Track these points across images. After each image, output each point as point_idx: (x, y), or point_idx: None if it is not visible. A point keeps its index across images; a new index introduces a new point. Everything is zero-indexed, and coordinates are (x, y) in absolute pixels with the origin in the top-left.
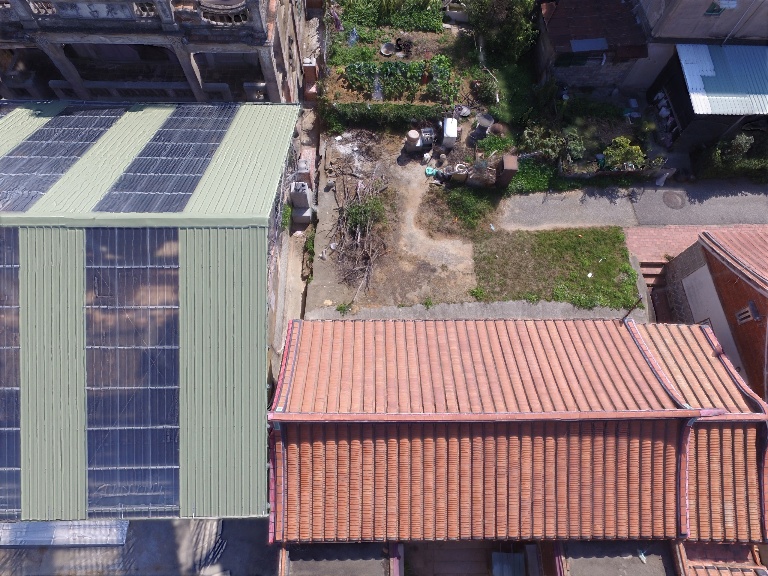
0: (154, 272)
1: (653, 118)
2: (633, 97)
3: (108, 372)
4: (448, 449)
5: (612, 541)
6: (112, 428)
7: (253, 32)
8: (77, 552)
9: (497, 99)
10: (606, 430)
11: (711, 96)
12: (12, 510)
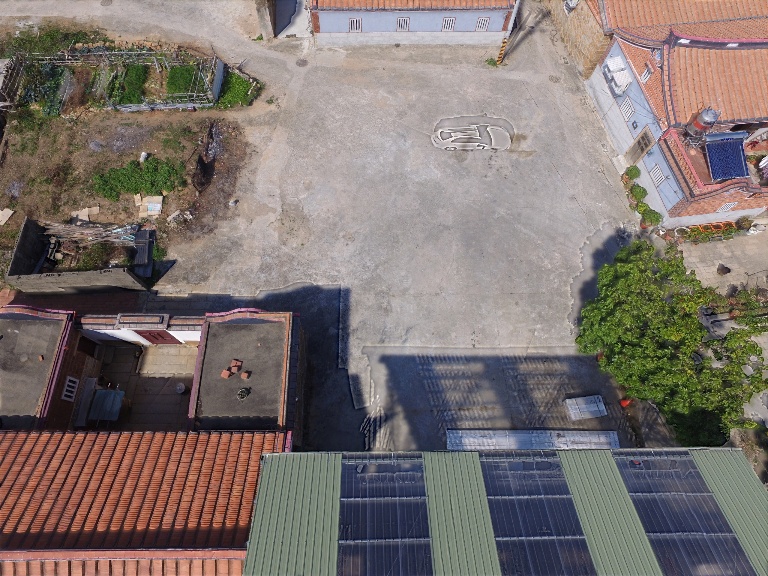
0: None
1: None
2: None
3: None
4: (98, 518)
5: None
6: (406, 540)
7: None
8: (485, 424)
9: None
10: None
11: None
12: (488, 460)
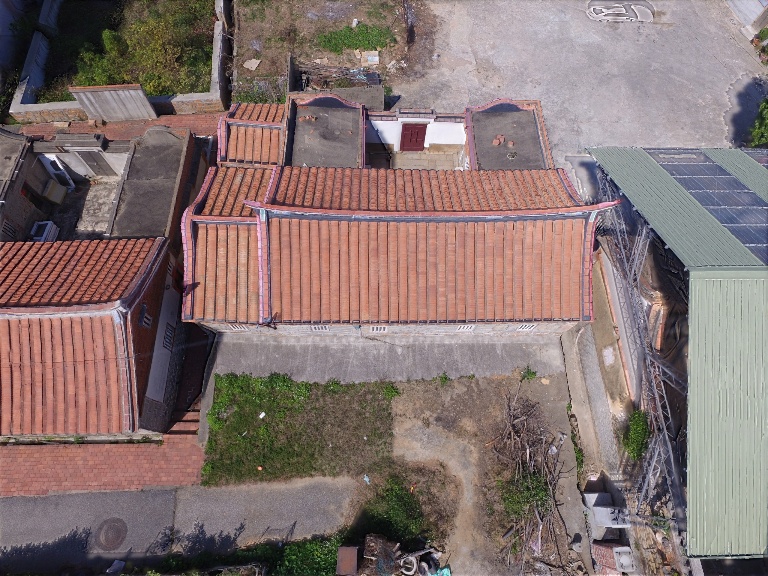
0: (760, 242)
1: None
2: None
3: None
4: (452, 206)
5: None
6: (717, 176)
7: None
8: None
9: None
10: None
11: None
12: (748, 152)
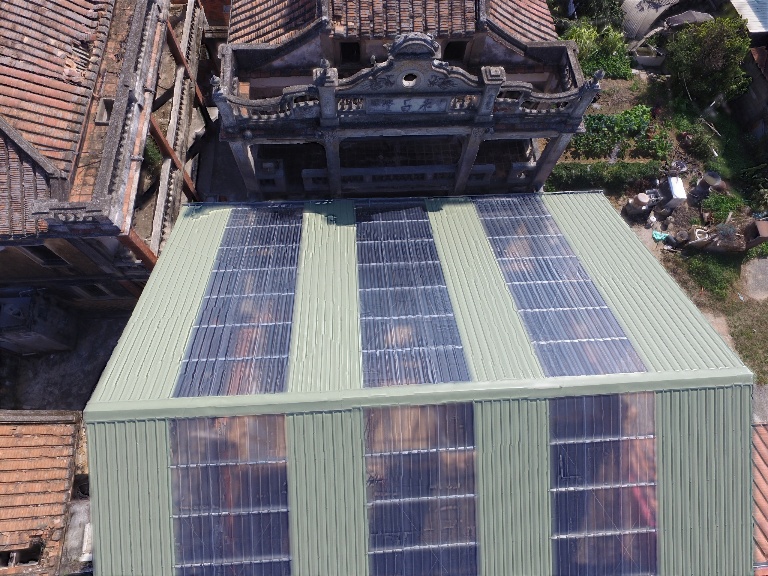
0: (626, 445)
1: None
2: None
3: (576, 565)
4: None
5: None
6: None
7: (569, 119)
8: None
9: (715, 153)
10: None
11: None
12: None
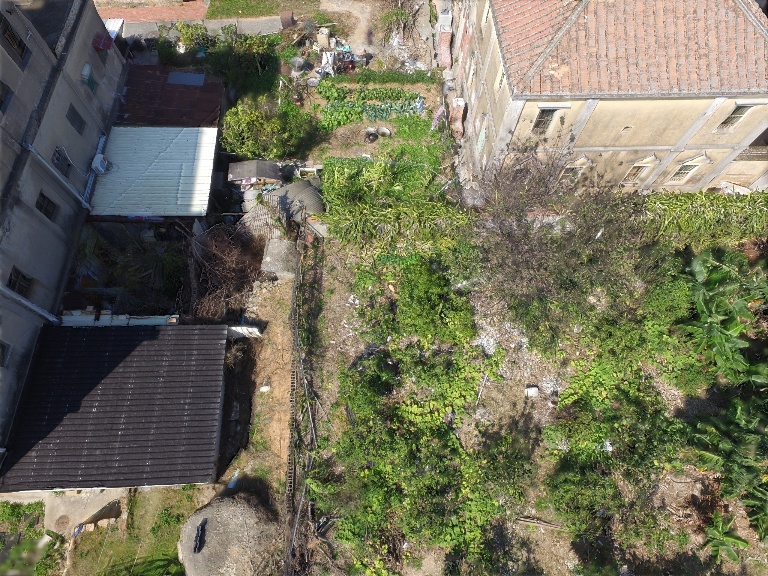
0: None
1: None
2: None
3: None
4: None
5: None
6: None
7: None
8: None
9: None
10: None
11: None
12: None
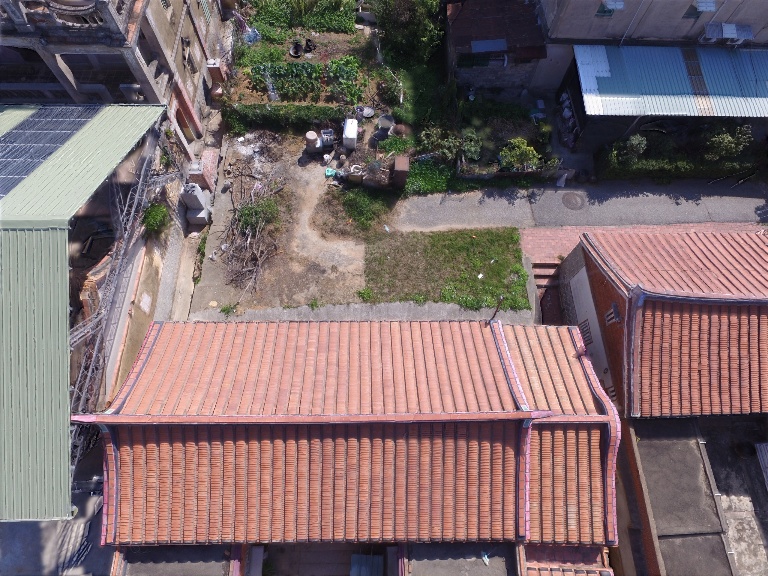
0: None
1: (558, 119)
2: (542, 98)
3: None
4: (286, 451)
5: (457, 543)
6: None
7: (110, 33)
8: None
9: (401, 100)
10: (445, 432)
11: (605, 97)
12: None
